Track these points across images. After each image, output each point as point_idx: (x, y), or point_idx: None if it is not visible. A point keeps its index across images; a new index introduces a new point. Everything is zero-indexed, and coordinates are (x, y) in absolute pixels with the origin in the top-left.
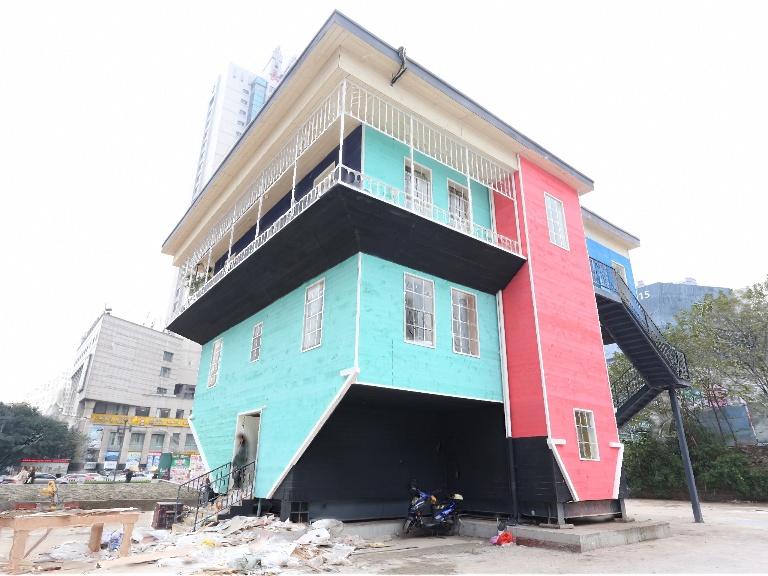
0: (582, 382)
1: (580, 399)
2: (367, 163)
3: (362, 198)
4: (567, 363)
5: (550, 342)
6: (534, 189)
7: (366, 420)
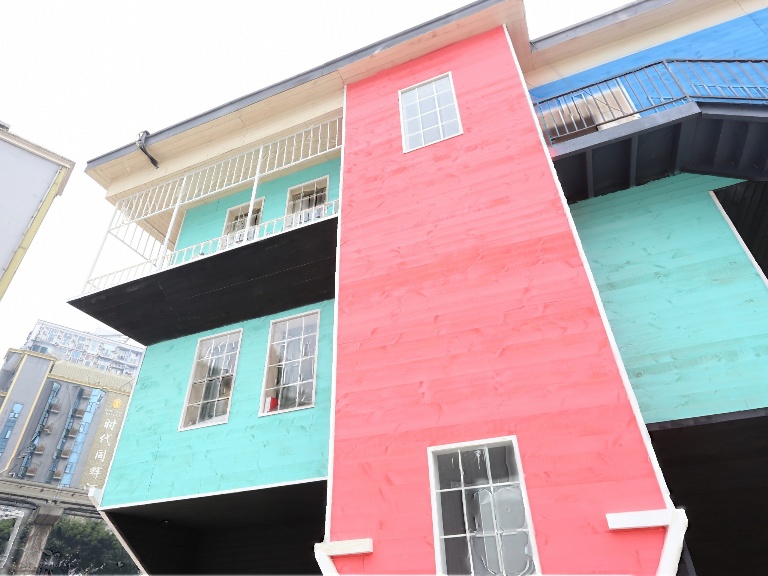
0: (476, 373)
1: (462, 418)
2: (179, 248)
3: (96, 299)
4: (422, 348)
5: (370, 327)
6: (375, 104)
7: (283, 546)
